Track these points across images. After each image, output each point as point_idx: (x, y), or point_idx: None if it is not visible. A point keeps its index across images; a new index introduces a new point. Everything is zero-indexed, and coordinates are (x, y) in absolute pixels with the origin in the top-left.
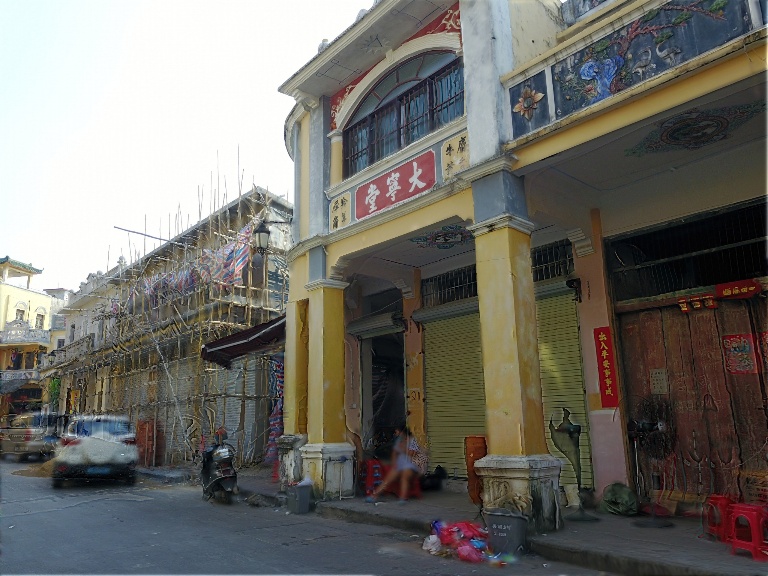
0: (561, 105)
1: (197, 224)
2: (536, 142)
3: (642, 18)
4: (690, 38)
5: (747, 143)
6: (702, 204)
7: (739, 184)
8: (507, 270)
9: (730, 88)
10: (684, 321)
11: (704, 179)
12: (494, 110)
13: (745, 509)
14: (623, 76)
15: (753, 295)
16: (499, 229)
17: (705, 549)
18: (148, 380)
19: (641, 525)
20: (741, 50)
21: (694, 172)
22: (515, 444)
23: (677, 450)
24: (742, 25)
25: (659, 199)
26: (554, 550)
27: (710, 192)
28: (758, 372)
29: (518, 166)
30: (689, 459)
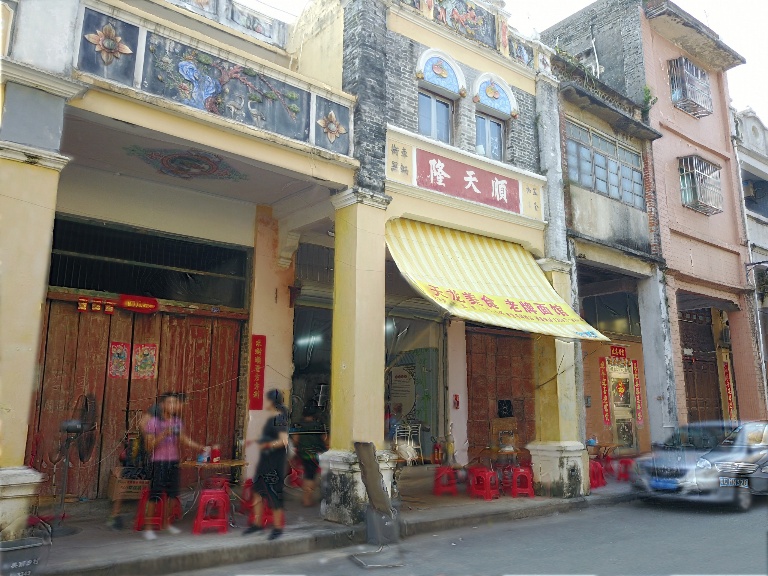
0: (150, 79)
1: None
2: (114, 96)
3: (243, 68)
4: (273, 115)
5: (184, 188)
6: (132, 218)
7: (166, 216)
8: (48, 224)
9: (283, 170)
10: (74, 319)
11: (140, 197)
12: (73, 20)
13: (221, 493)
14: (219, 102)
15: (153, 312)
16: (47, 168)
17: (182, 535)
18: None
19: (56, 535)
20: (305, 153)
21: (133, 187)
22: (15, 451)
23: (41, 452)
24: (304, 134)
25: (93, 194)
26: (76, 575)
27: (142, 211)
28: (129, 378)
29: (81, 105)
30: (47, 461)
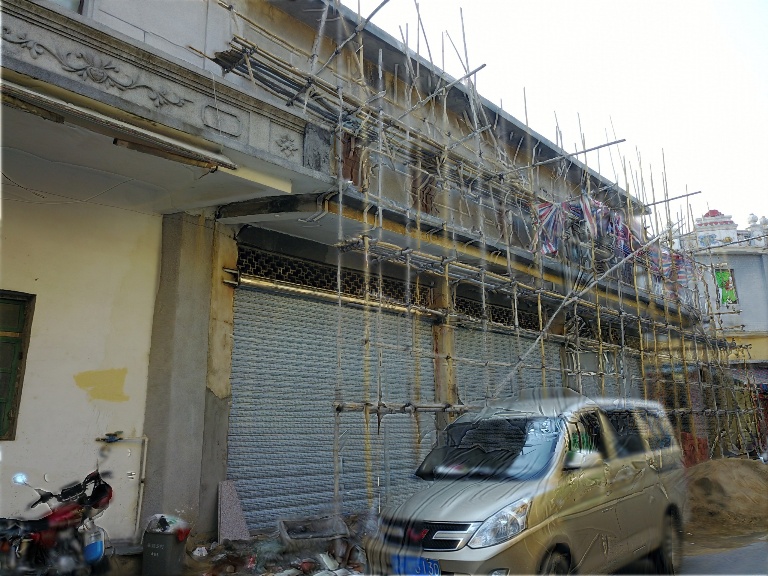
0: None
1: (592, 171)
2: None
3: None
4: None
5: None
6: None
7: None
8: None
9: None
10: None
11: None
12: None
13: None
14: None
15: None
16: None
17: None
18: (699, 379)
19: None
20: None
21: None
22: None
23: None
24: None
25: None
26: None
27: None
28: None
29: None
30: None
